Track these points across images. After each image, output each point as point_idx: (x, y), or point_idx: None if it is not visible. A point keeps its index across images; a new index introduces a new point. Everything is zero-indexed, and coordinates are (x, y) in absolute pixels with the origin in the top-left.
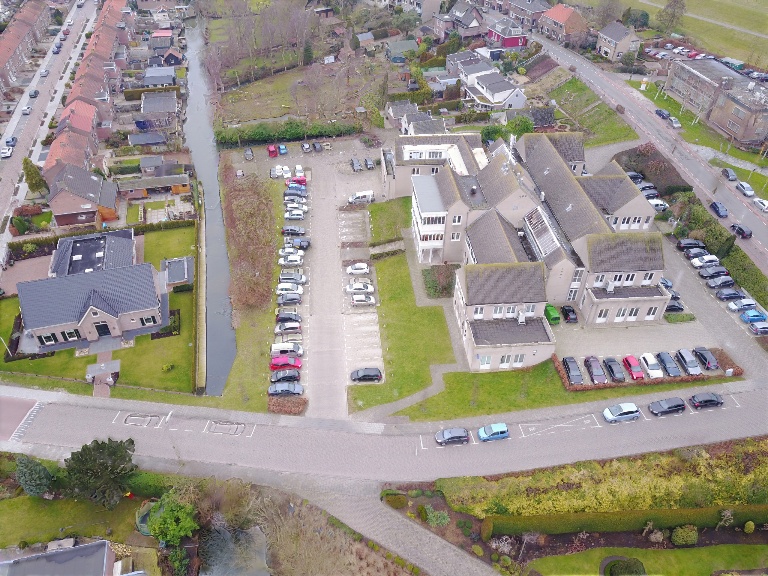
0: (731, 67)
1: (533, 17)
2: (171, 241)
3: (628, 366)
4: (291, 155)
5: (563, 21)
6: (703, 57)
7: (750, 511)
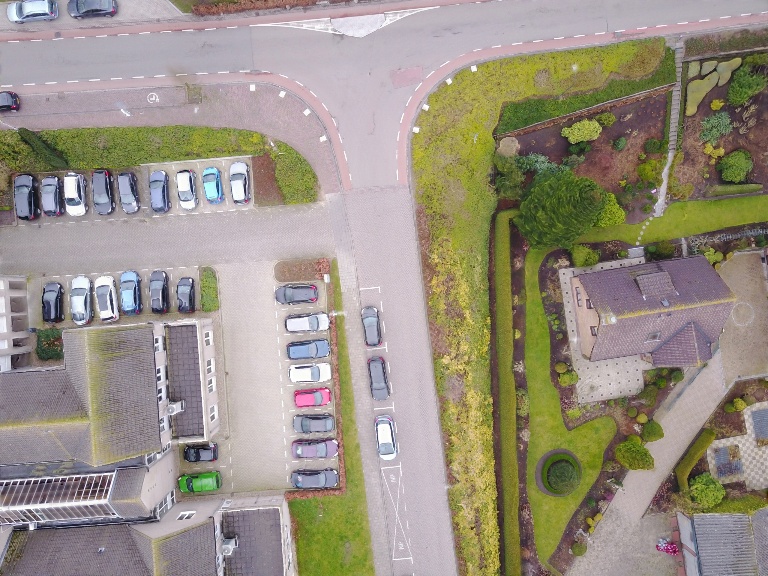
0: None
1: None
2: None
3: None
4: None
5: None
6: None
7: (512, 338)
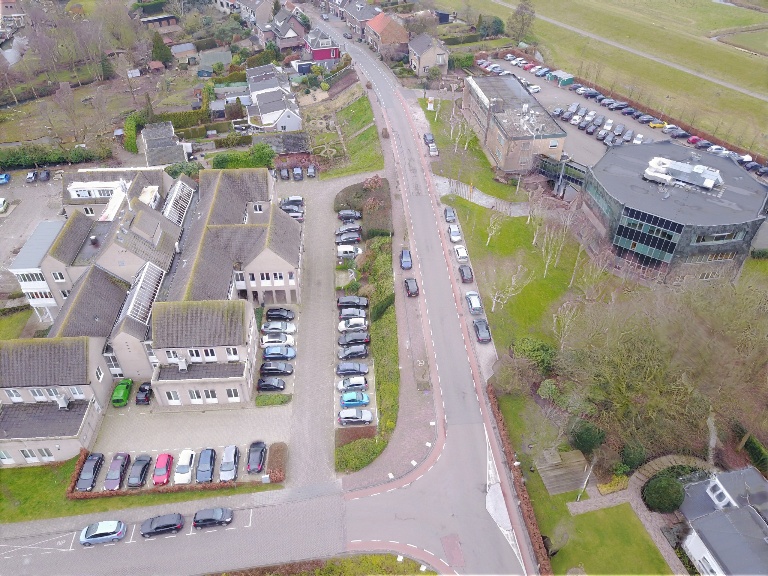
0: (523, 85)
1: (361, 26)
2: None
3: None
4: (11, 185)
5: (379, 31)
6: (538, 69)
7: None
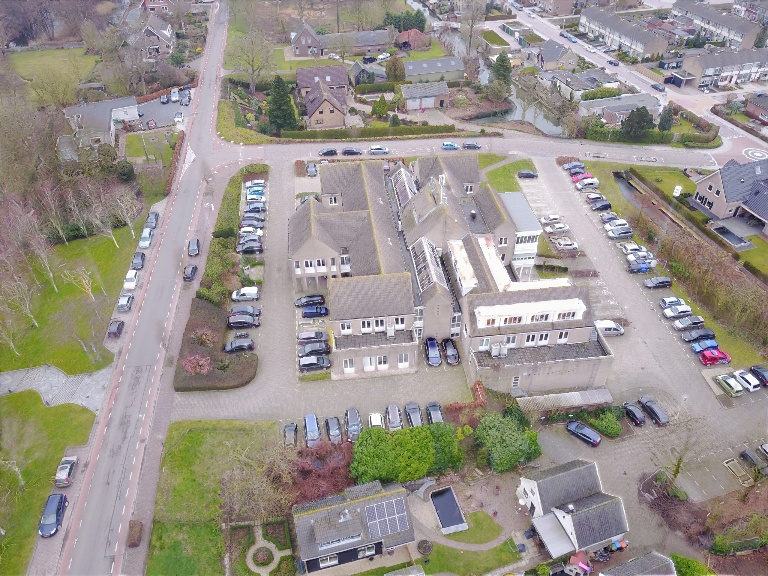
0: None
1: None
2: None
3: None
4: None
5: None
6: None
7: None
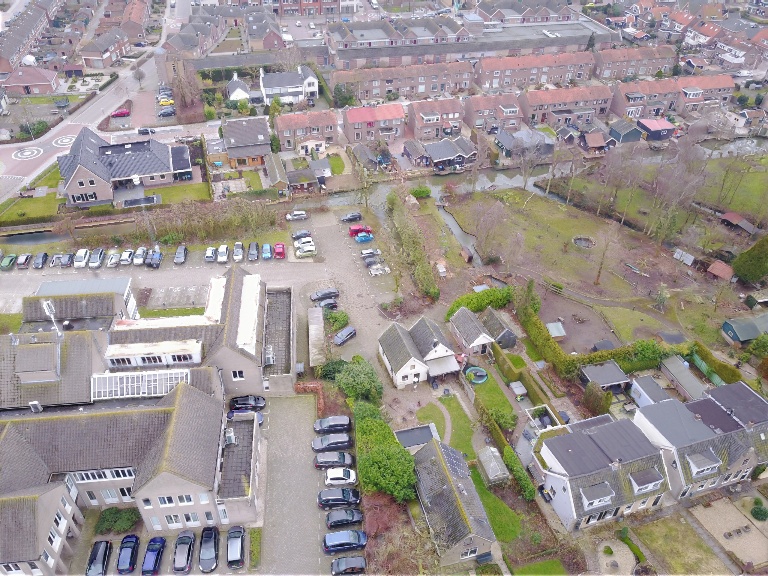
0: None
1: None
2: (188, 195)
3: None
4: (355, 246)
5: None
6: None
7: None
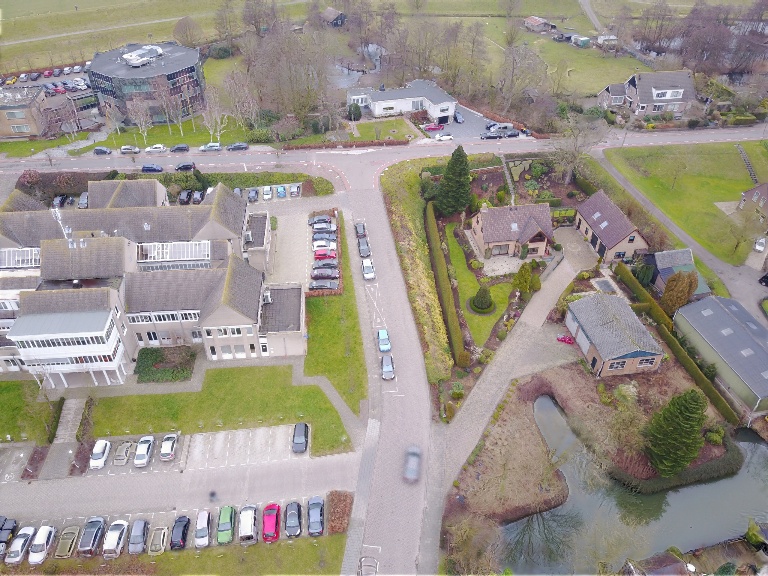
0: None
1: None
2: None
3: (324, 256)
4: None
5: None
6: None
7: None
